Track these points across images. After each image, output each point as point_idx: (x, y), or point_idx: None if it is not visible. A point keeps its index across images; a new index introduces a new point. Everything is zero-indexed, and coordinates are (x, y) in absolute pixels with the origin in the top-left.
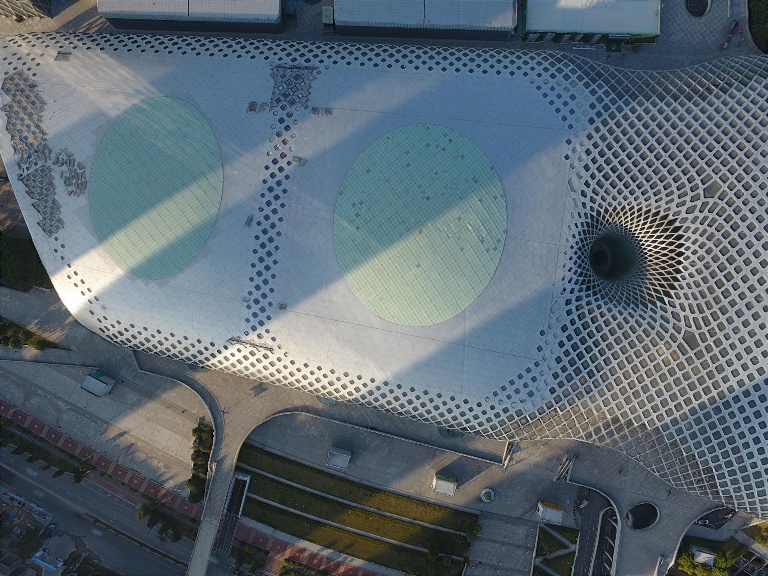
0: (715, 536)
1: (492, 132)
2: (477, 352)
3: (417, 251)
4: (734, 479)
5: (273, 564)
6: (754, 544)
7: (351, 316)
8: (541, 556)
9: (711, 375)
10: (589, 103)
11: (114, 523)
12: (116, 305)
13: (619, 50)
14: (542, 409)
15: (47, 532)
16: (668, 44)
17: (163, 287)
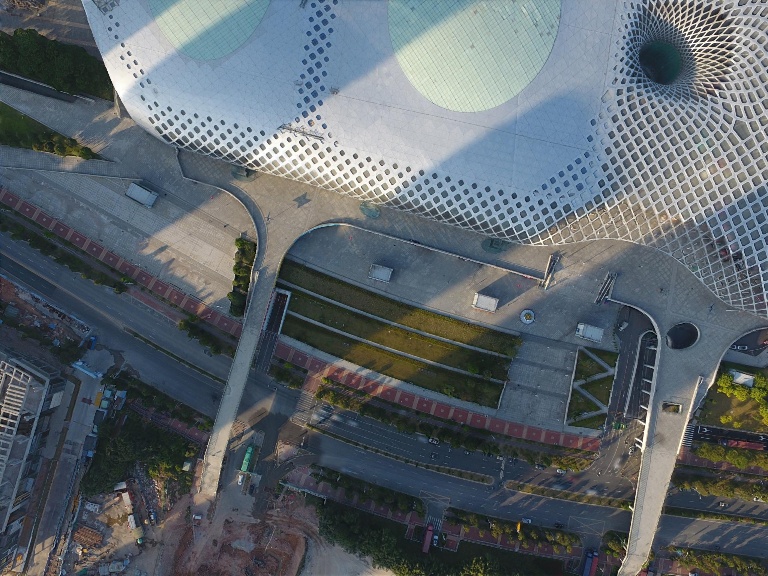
0: (754, 362)
1: None
2: (528, 141)
3: (472, 32)
4: None
5: (311, 383)
6: None
7: (403, 101)
8: (580, 380)
9: (761, 165)
10: None
11: (153, 338)
12: (168, 88)
13: None
14: (590, 204)
15: (86, 346)
16: None
17: (216, 68)
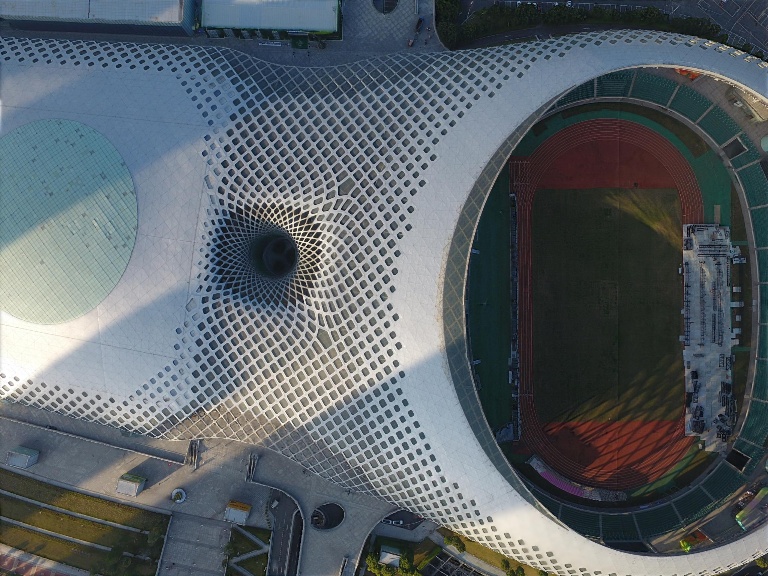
0: (410, 537)
1: (128, 128)
2: (114, 350)
3: (40, 248)
4: (384, 479)
5: None
6: (449, 545)
7: None
8: (235, 557)
9: (344, 374)
10: (233, 99)
11: None
12: None
13: (305, 47)
14: (188, 408)
15: None
16: (355, 41)
17: None
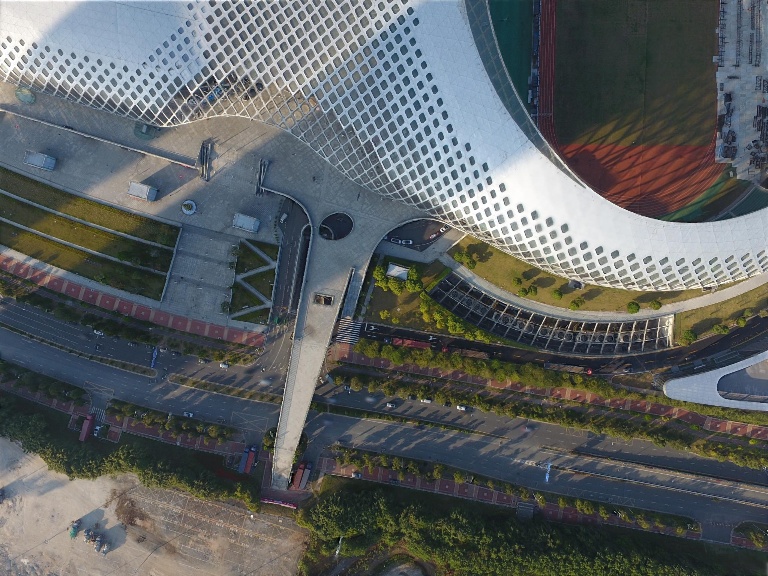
0: (419, 258)
1: None
2: (129, 10)
3: None
4: (394, 155)
5: None
6: (459, 267)
7: None
8: (243, 273)
9: (357, 30)
10: None
11: None
12: None
13: None
14: (199, 77)
15: None
16: None
17: None
